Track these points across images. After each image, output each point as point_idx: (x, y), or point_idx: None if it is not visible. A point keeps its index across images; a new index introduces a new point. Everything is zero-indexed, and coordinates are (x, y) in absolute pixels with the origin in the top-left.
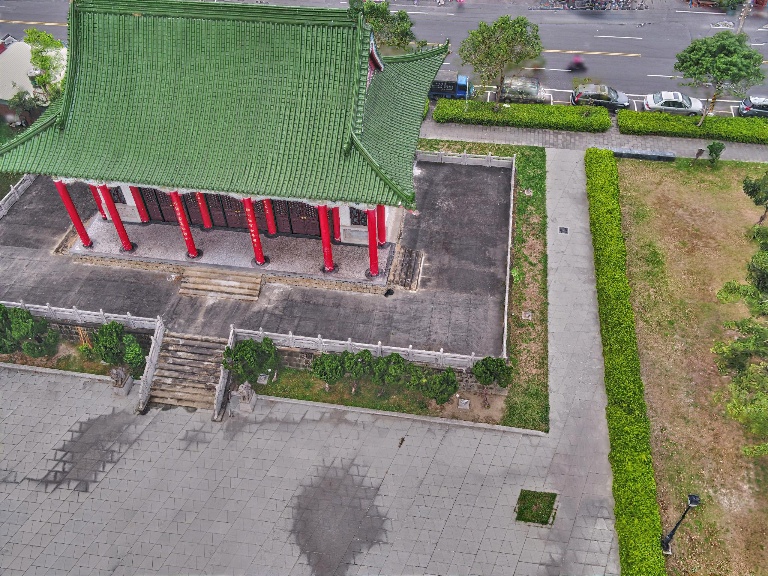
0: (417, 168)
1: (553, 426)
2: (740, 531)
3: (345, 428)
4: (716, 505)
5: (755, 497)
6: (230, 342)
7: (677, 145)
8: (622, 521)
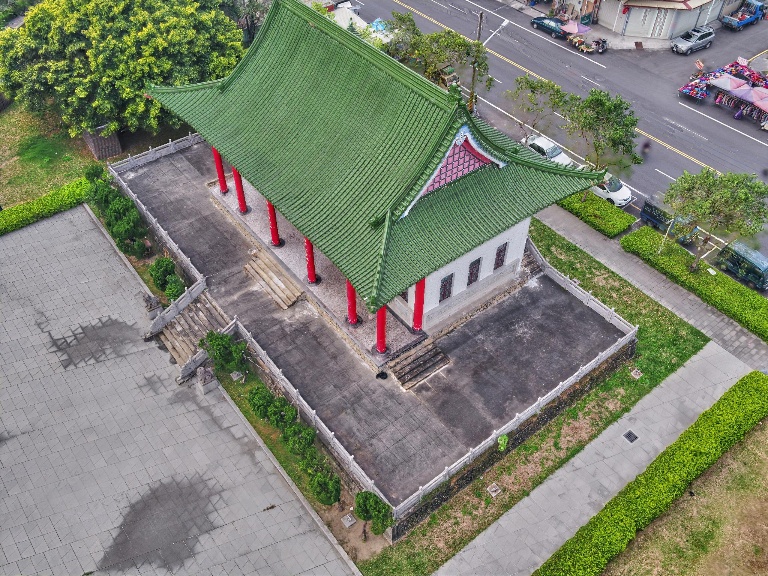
0: (537, 280)
1: None
2: None
3: (246, 460)
4: None
5: None
6: (226, 328)
7: None
8: None
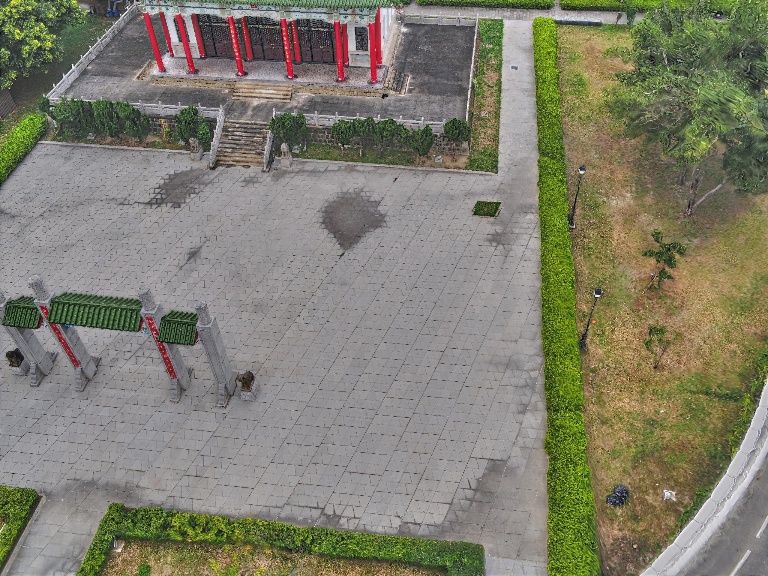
0: (404, 27)
1: (501, 170)
2: (622, 215)
3: (356, 174)
4: (608, 205)
5: (634, 199)
6: None
7: (605, 16)
8: (543, 208)
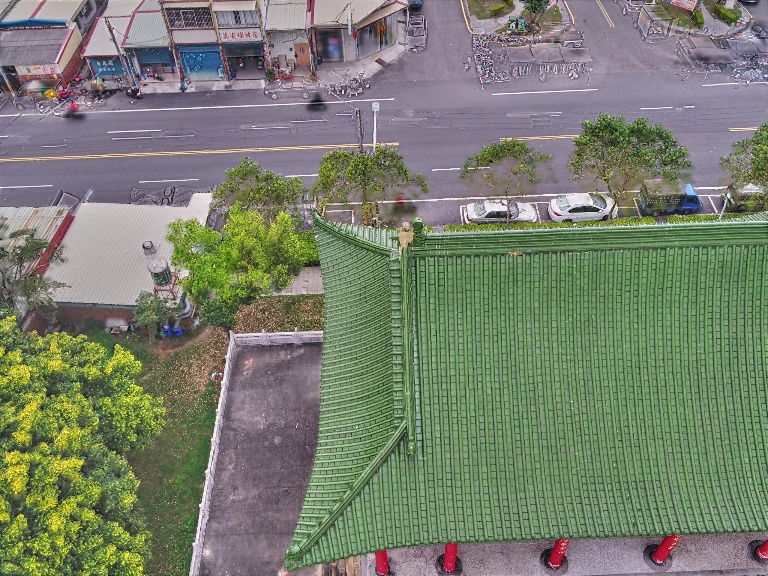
0: None
1: None
2: None
3: None
4: None
5: None
6: None
7: None
8: None
